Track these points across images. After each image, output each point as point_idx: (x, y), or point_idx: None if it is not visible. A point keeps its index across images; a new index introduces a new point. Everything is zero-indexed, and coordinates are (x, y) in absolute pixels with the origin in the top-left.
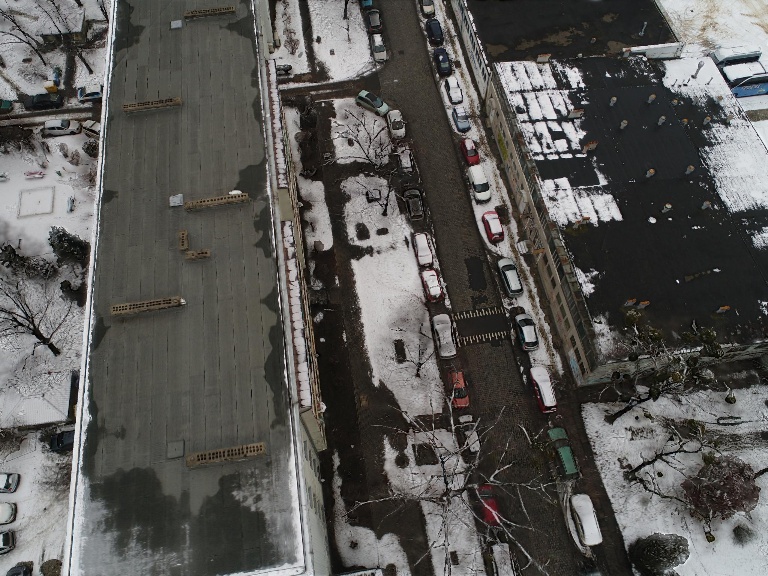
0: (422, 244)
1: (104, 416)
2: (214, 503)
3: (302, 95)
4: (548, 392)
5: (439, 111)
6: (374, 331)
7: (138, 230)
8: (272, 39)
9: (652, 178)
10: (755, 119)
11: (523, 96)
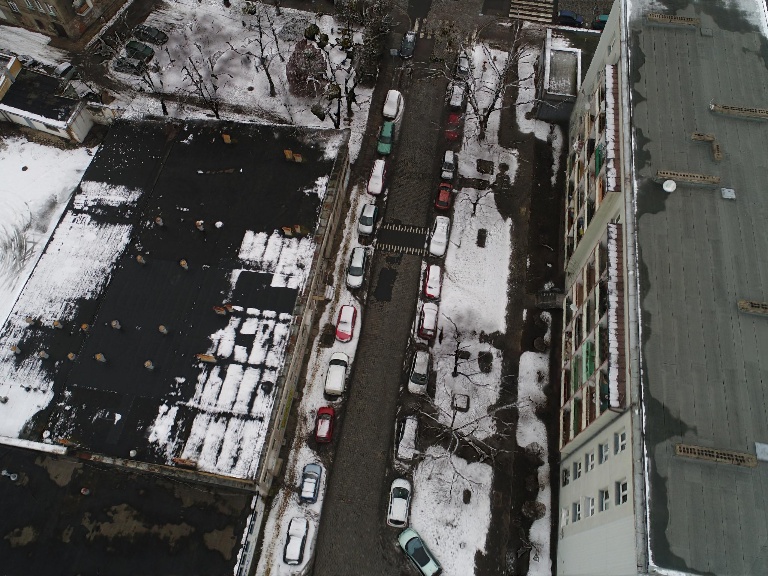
0: (431, 317)
1: (760, 62)
2: (679, 6)
3: None
4: (378, 168)
5: (331, 514)
6: (500, 260)
7: (761, 179)
8: None
9: None
10: None
11: (250, 410)
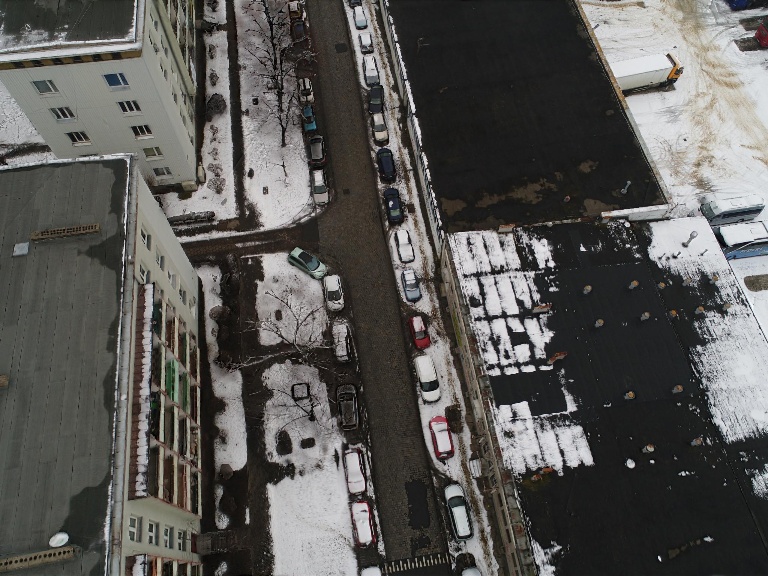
0: (353, 467)
1: None
2: None
3: (224, 253)
4: None
5: (386, 272)
6: None
7: None
8: (194, 176)
9: (632, 400)
10: (756, 288)
11: (479, 281)
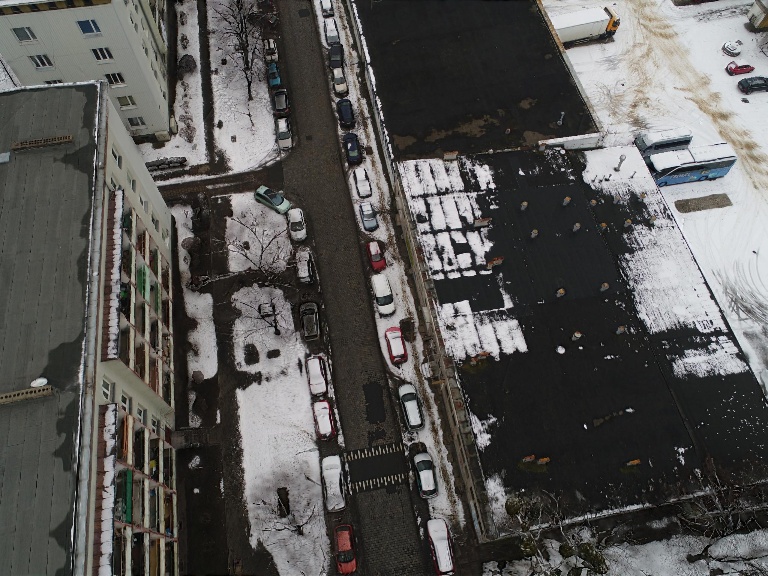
0: (314, 371)
1: None
2: None
3: (195, 192)
4: (444, 553)
5: (346, 206)
6: (256, 478)
7: None
8: (167, 127)
9: (563, 297)
10: (686, 210)
11: (426, 201)
